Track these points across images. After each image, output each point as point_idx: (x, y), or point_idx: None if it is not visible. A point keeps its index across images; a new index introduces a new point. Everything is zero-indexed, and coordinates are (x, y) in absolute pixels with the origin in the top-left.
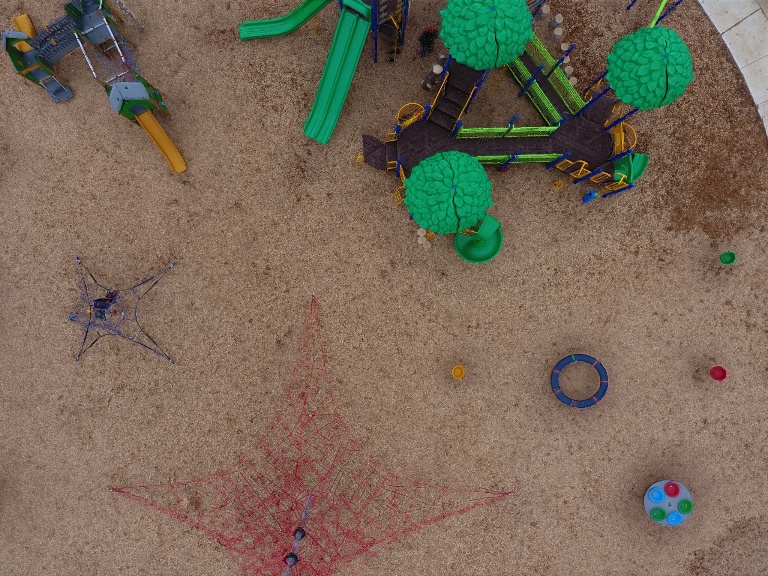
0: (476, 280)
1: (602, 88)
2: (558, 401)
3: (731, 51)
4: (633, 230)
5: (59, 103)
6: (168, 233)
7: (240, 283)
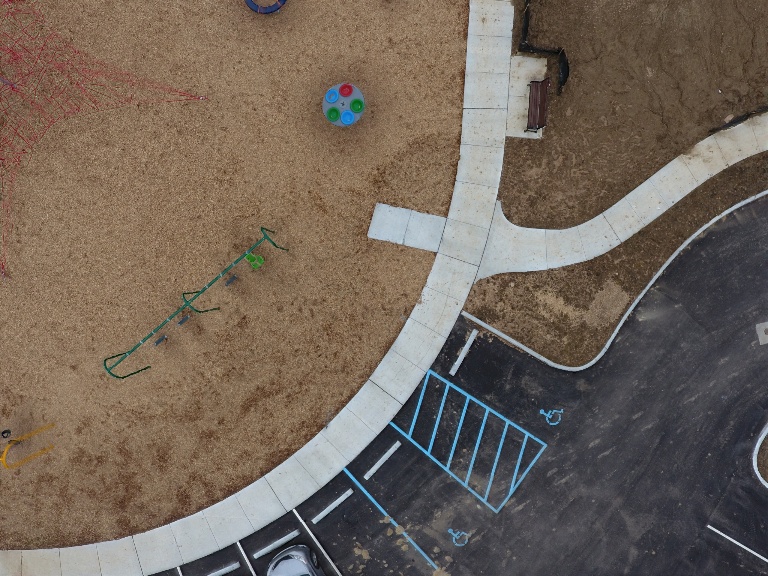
0: None
1: None
2: (251, 13)
3: None
4: None
5: None
6: None
7: None
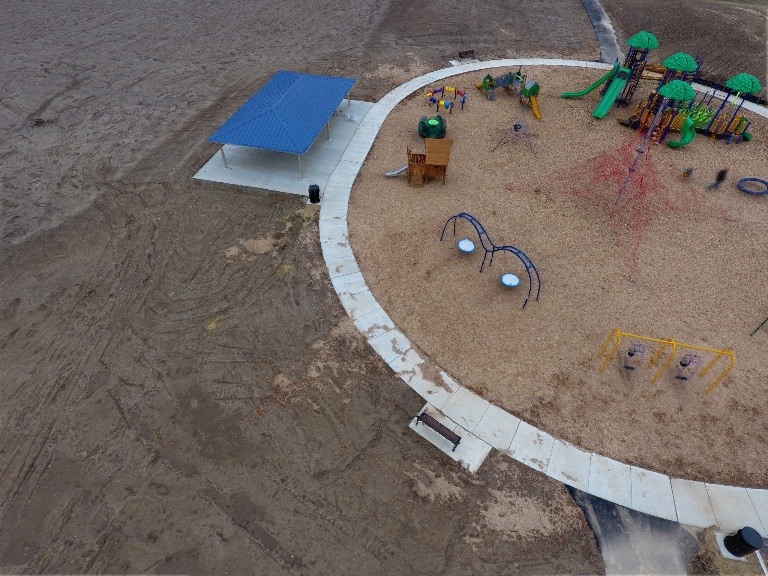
0: None
1: None
2: (746, 195)
3: None
4: None
5: (489, 100)
6: None
7: None
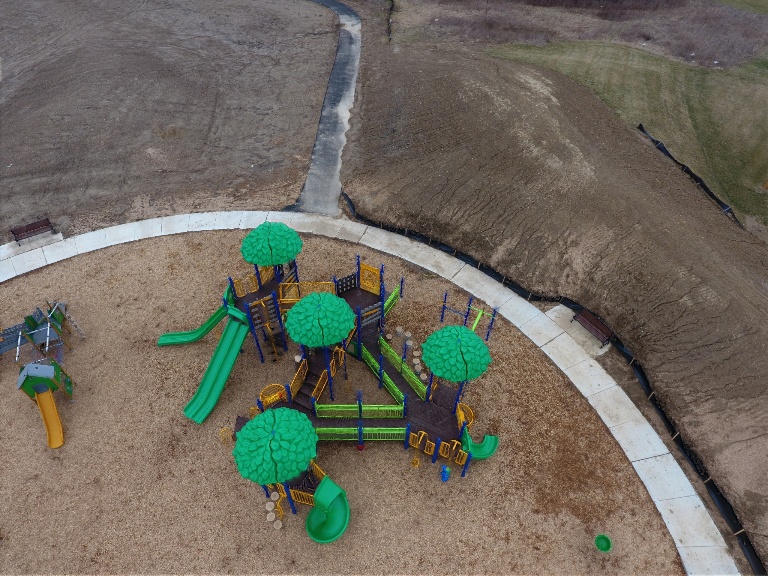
0: (329, 571)
1: (451, 383)
2: None
3: (551, 358)
4: (499, 513)
5: None
6: (9, 510)
7: (58, 572)
